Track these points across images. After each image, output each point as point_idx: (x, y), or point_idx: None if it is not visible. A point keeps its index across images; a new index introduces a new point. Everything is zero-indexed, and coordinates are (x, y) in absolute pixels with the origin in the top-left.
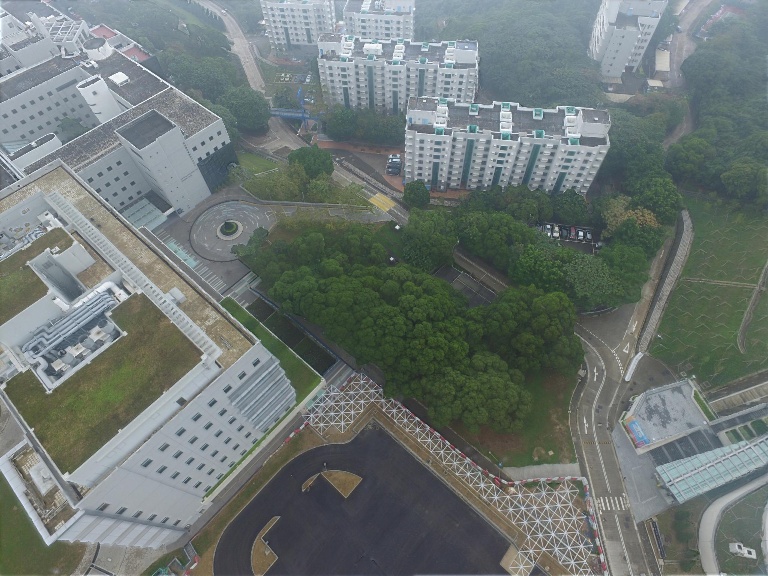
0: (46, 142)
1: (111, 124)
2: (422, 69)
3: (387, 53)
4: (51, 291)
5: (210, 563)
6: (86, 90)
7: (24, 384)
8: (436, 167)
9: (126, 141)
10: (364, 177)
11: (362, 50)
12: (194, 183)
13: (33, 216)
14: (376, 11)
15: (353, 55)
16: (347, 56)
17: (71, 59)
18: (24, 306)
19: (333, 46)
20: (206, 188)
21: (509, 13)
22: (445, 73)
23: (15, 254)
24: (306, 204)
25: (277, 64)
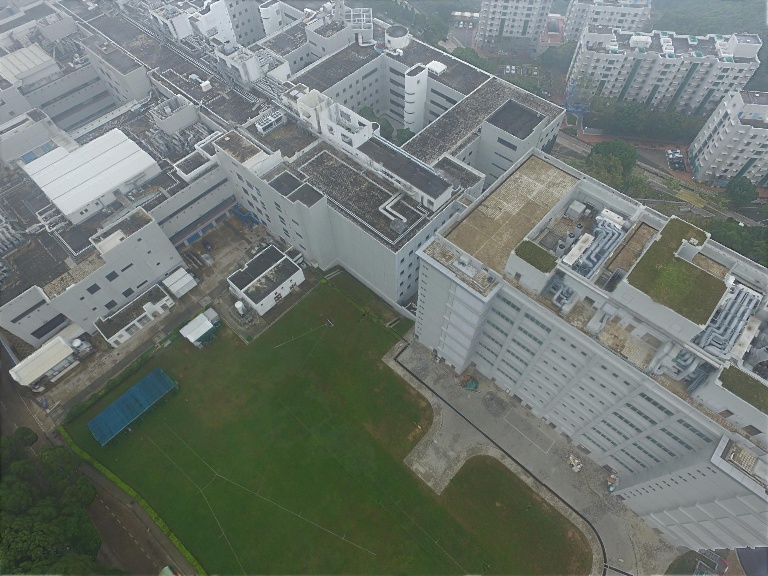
0: None
1: (453, 114)
2: (697, 63)
3: (654, 46)
4: (729, 284)
5: (738, 567)
6: (415, 78)
7: (740, 381)
8: (750, 163)
9: (502, 131)
10: (658, 172)
11: (627, 42)
12: None
13: (562, 206)
14: (610, 3)
15: (619, 47)
16: (615, 48)
17: (368, 47)
18: (713, 299)
19: (603, 38)
20: None
21: (730, 7)
22: (724, 67)
23: (654, 245)
24: None
25: (485, 56)
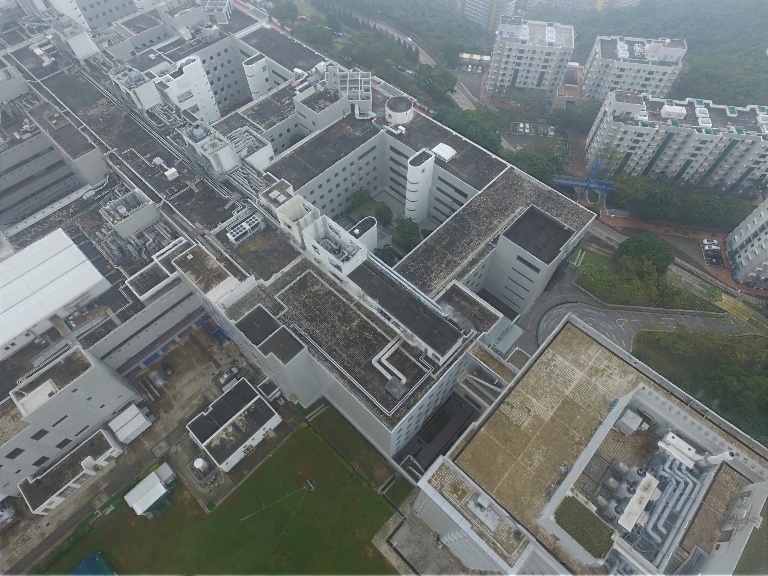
0: (369, 229)
1: (463, 215)
2: (737, 139)
3: (689, 117)
4: None
5: None
6: (419, 168)
7: None
8: None
9: (523, 250)
10: (693, 271)
11: (658, 112)
12: (543, 285)
13: None
14: (636, 59)
15: (649, 118)
16: (645, 119)
17: (366, 120)
18: None
19: (632, 108)
20: (544, 287)
21: (766, 63)
22: (767, 146)
23: (754, 537)
24: (655, 309)
25: (495, 107)
